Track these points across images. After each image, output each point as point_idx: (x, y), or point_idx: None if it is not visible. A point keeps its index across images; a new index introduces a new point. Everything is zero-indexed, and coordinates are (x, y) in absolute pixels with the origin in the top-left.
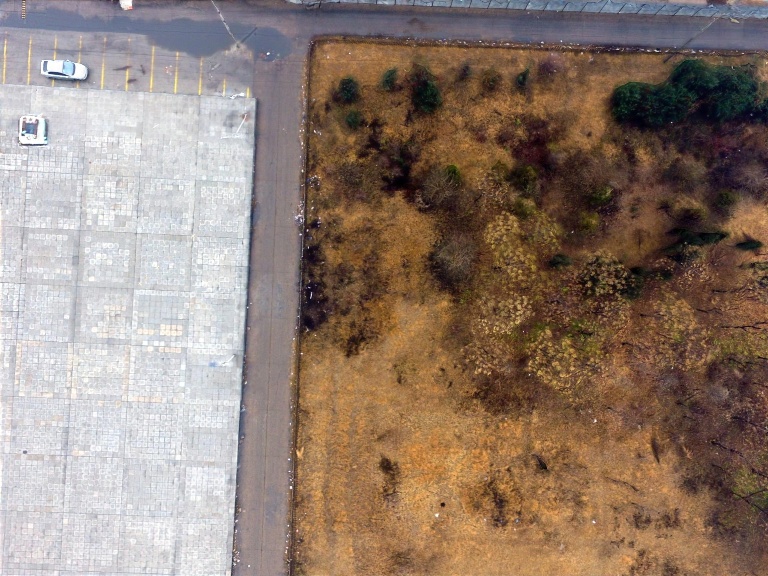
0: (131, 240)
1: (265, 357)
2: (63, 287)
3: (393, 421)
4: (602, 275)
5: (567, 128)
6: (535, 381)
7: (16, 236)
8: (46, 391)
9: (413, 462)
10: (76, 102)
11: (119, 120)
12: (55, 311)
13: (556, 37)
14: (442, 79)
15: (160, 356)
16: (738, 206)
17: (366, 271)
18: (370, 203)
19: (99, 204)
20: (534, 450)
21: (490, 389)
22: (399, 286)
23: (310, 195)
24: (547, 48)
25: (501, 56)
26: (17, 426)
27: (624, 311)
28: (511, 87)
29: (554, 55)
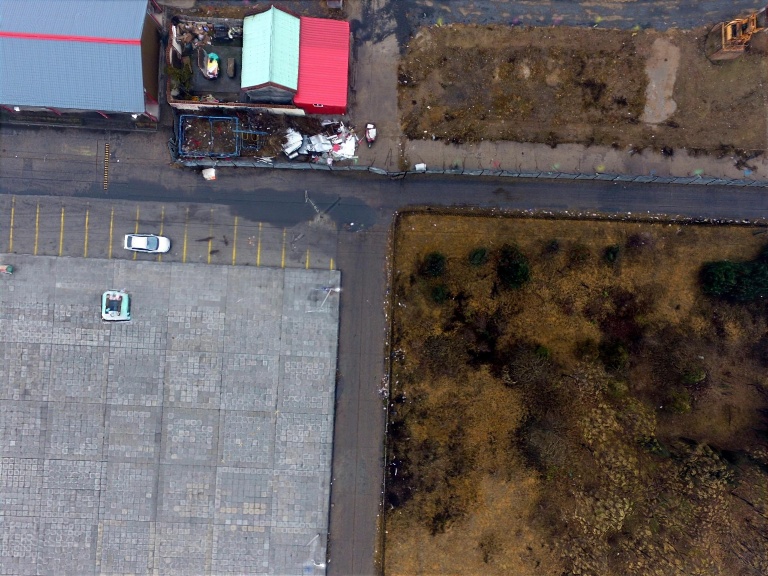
0: (214, 417)
1: (349, 534)
2: (145, 465)
3: None
4: (704, 477)
5: (655, 301)
6: (624, 561)
7: (98, 413)
8: (128, 572)
9: None
10: (159, 276)
11: (202, 294)
12: (137, 489)
13: (643, 207)
14: (528, 251)
15: (243, 535)
16: None
17: (452, 447)
18: (456, 377)
19: (182, 380)
20: None
21: None
22: (485, 463)
23: (395, 369)
24: (635, 221)
25: (588, 228)
26: None
27: (728, 515)
28: (598, 260)
29: (642, 227)
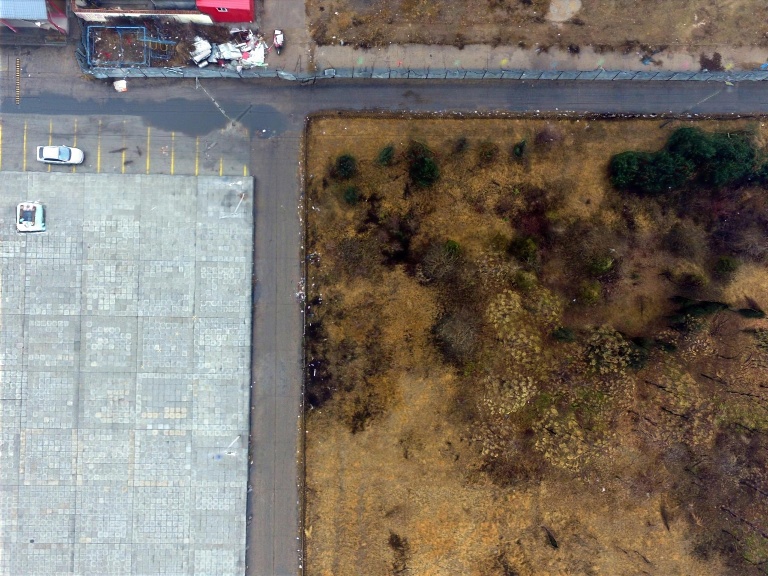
0: (132, 324)
1: (270, 436)
2: (65, 373)
3: (401, 497)
4: (606, 353)
5: (565, 196)
6: (542, 452)
7: (17, 324)
8: (51, 479)
9: (422, 537)
10: (73, 187)
11: (117, 203)
12: (58, 398)
13: (551, 105)
14: (439, 151)
15: (165, 439)
16: (739, 269)
17: (369, 346)
18: (371, 278)
19: (99, 288)
20: (543, 522)
21: (497, 461)
22: (402, 360)
23: (310, 272)
24: (543, 117)
25: (497, 126)
26: (23, 515)
27: (629, 389)
28: (508, 157)
29: (550, 123)
